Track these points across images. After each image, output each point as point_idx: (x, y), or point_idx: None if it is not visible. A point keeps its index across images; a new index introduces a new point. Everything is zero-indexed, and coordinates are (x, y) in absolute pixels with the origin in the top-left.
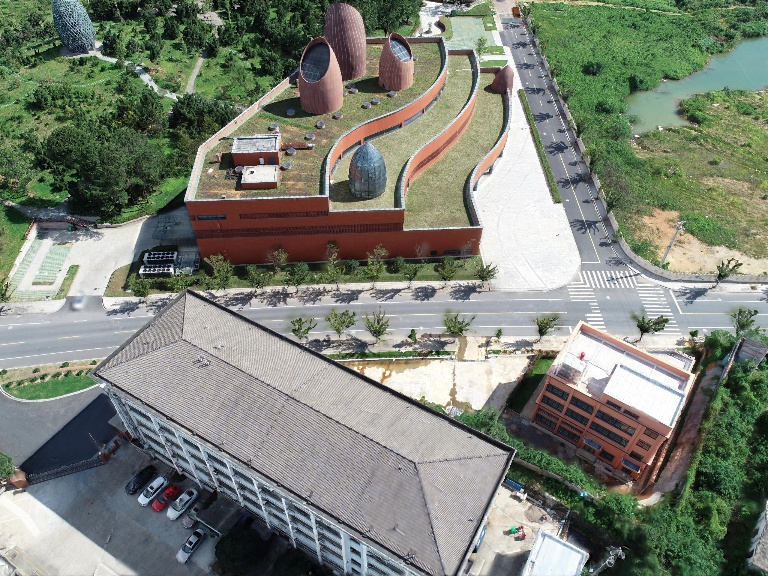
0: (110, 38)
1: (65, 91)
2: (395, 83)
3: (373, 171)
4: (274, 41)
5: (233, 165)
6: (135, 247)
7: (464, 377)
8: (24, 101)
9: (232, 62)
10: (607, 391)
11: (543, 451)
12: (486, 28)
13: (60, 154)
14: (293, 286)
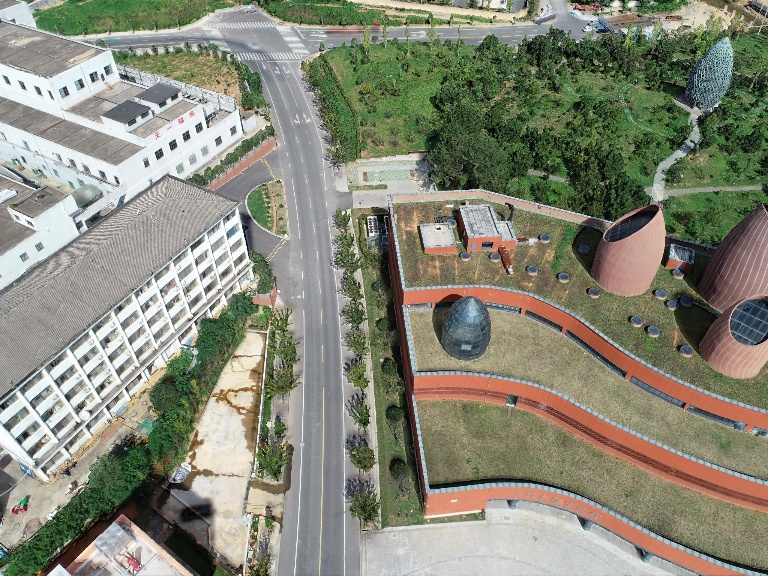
0: None
1: (610, 113)
2: (707, 346)
3: (450, 323)
4: None
5: None
6: None
7: (225, 486)
8: None
9: None
10: (61, 571)
11: None
12: None
13: None
14: (367, 326)
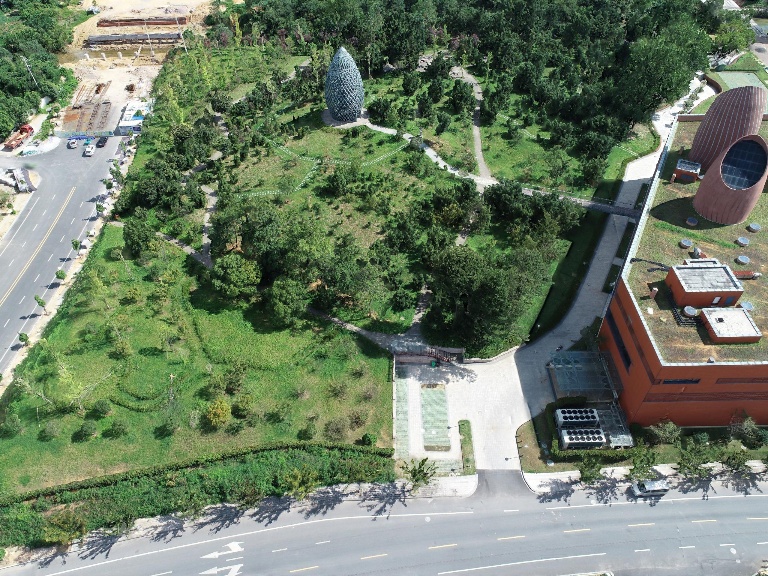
0: (381, 105)
1: (355, 172)
2: None
3: None
4: (552, 106)
5: (675, 303)
6: (524, 394)
7: None
8: (312, 185)
9: (521, 134)
10: None
11: None
12: (767, 87)
13: (458, 284)
14: (754, 462)
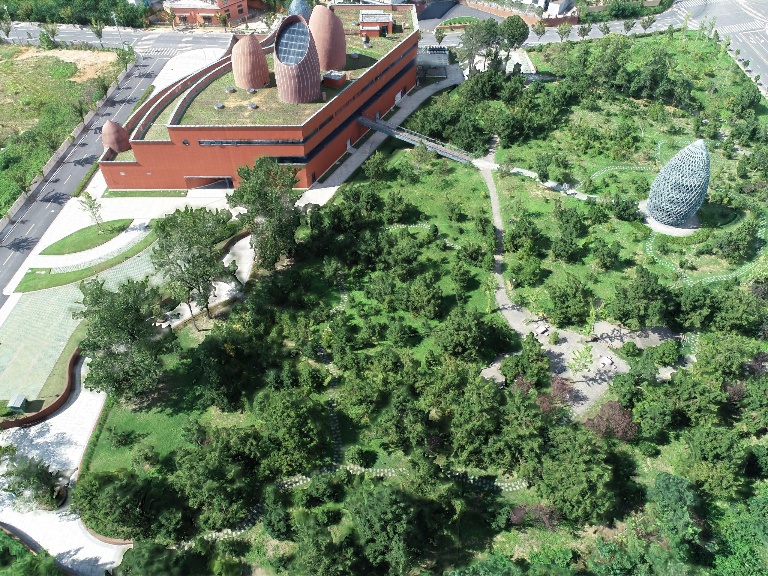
0: None
1: None
2: None
3: None
4: None
5: None
6: None
7: None
8: None
9: None
10: None
11: (249, 9)
12: None
13: None
14: None
